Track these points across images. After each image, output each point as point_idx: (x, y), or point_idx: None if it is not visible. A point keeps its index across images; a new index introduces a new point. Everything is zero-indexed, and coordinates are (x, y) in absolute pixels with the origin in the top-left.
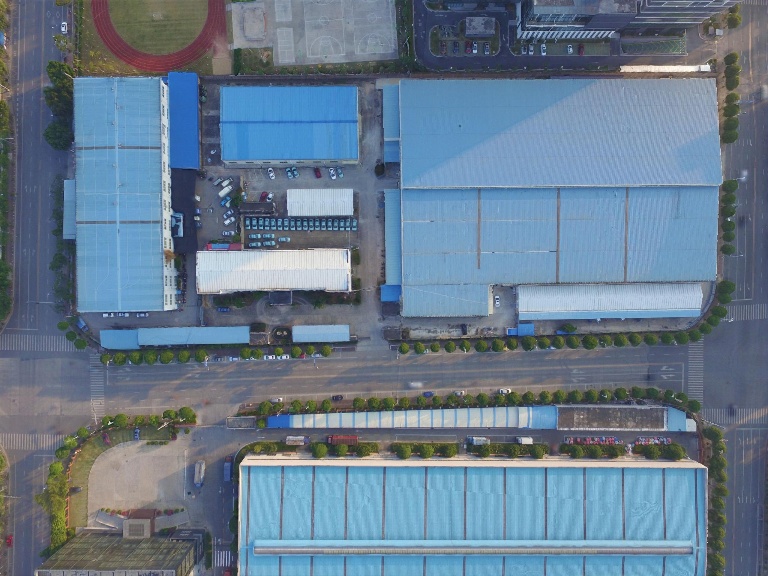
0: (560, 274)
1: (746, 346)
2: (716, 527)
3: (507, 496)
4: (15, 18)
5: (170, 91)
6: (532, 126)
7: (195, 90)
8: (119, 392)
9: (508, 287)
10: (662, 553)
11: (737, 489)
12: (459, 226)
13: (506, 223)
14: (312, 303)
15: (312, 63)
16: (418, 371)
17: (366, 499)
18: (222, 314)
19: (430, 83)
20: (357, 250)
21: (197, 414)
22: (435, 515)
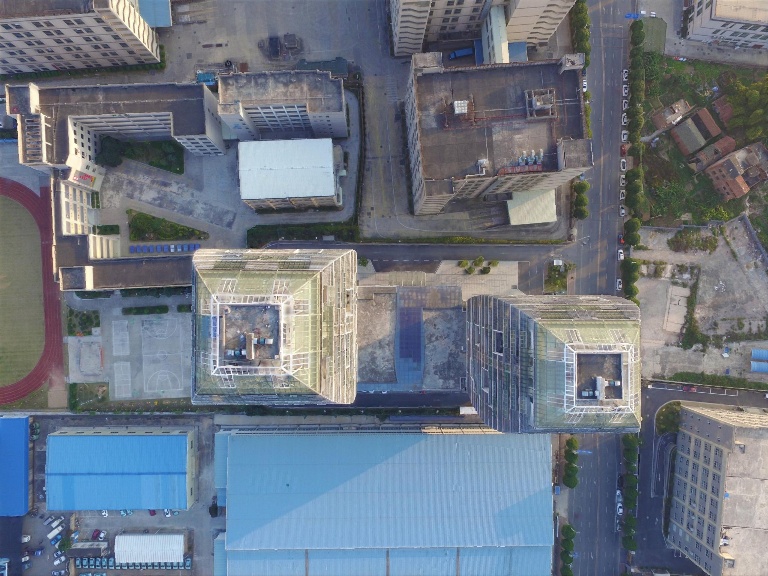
0: None
1: None
2: None
3: None
4: None
5: None
6: (361, 485)
7: (23, 436)
8: None
9: None
10: None
11: None
12: None
13: None
14: None
15: (149, 398)
16: None
17: None
18: None
19: (259, 439)
20: None
21: None
22: None
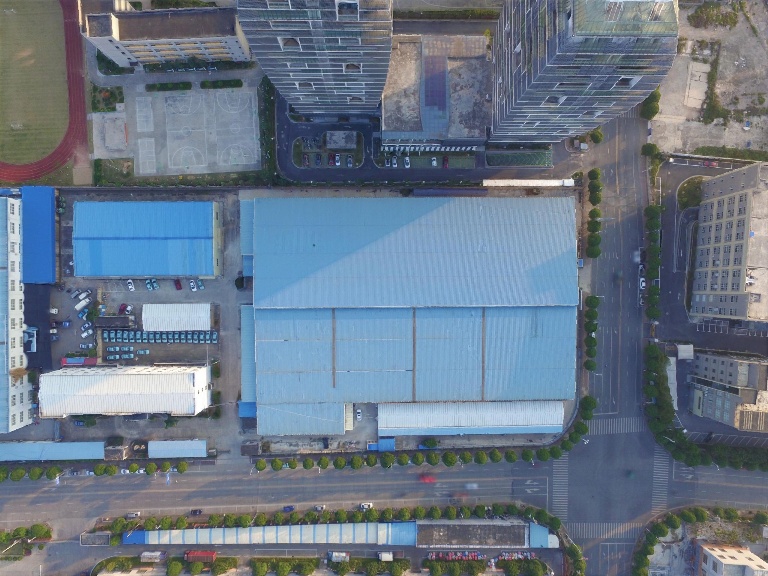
0: (417, 393)
1: (611, 460)
2: None
3: None
4: None
5: (23, 206)
6: (387, 245)
7: (49, 204)
8: None
9: None
10: None
11: None
12: (313, 345)
13: (361, 342)
14: None
15: (174, 174)
16: (279, 485)
17: None
18: (79, 427)
19: (285, 201)
20: (217, 363)
21: (52, 529)
22: None
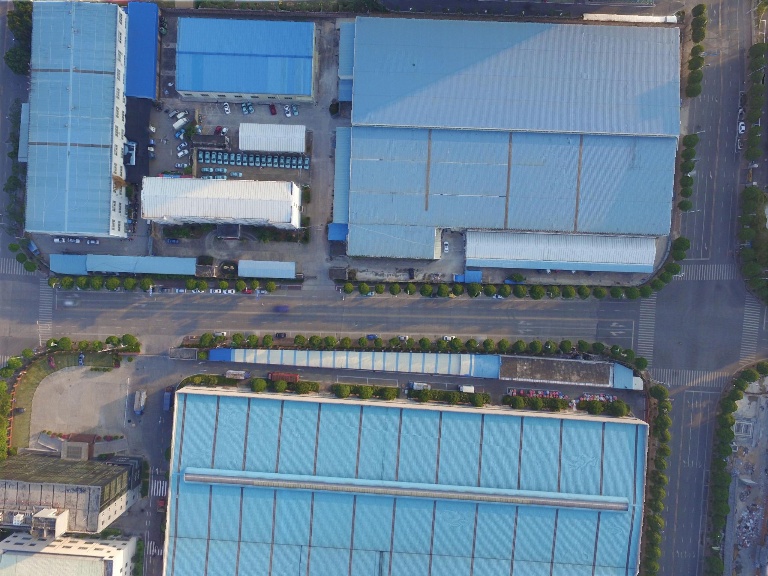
0: (509, 220)
1: (700, 307)
2: (657, 488)
3: (442, 440)
4: None
5: (129, 20)
6: (487, 68)
7: (154, 20)
8: (67, 317)
9: (458, 233)
10: (596, 508)
11: (683, 453)
12: (408, 166)
13: (456, 165)
14: (258, 237)
15: None
16: (363, 313)
17: (296, 431)
18: (171, 246)
19: (386, 21)
20: (308, 189)
21: (141, 343)
22: (368, 454)
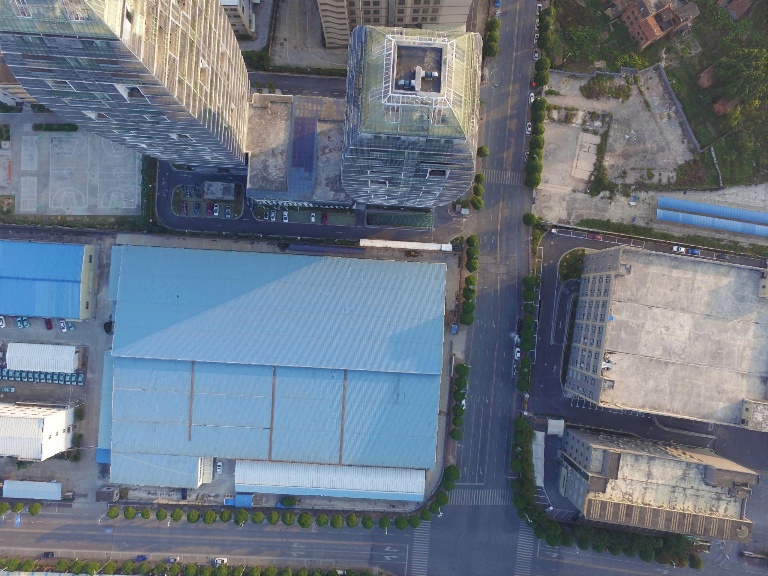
0: (273, 452)
1: (475, 532)
2: None
3: None
4: None
5: None
6: (252, 301)
7: None
8: None
9: None
10: None
11: None
12: (171, 397)
13: (219, 397)
14: None
15: (53, 213)
16: (134, 533)
17: None
18: None
19: (153, 250)
20: (82, 405)
21: None
22: None
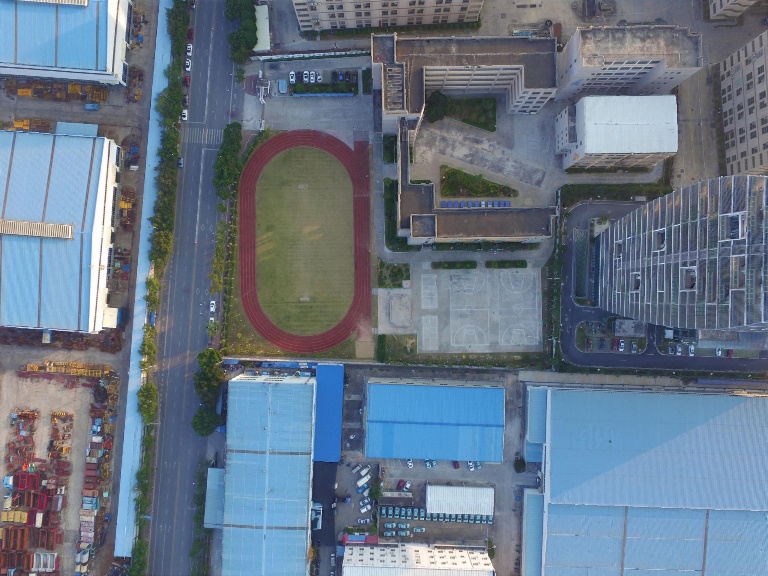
0: None
1: None
2: None
3: None
4: (165, 294)
5: (317, 384)
6: (684, 445)
7: (342, 383)
8: None
9: None
10: None
11: None
12: (604, 541)
13: (652, 541)
14: None
15: (455, 352)
16: None
17: None
18: None
19: (581, 394)
20: (492, 543)
21: None
22: None
